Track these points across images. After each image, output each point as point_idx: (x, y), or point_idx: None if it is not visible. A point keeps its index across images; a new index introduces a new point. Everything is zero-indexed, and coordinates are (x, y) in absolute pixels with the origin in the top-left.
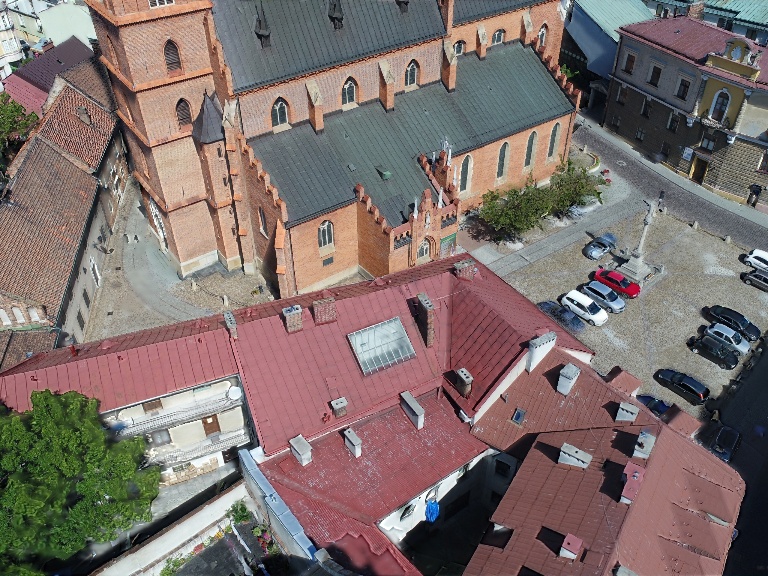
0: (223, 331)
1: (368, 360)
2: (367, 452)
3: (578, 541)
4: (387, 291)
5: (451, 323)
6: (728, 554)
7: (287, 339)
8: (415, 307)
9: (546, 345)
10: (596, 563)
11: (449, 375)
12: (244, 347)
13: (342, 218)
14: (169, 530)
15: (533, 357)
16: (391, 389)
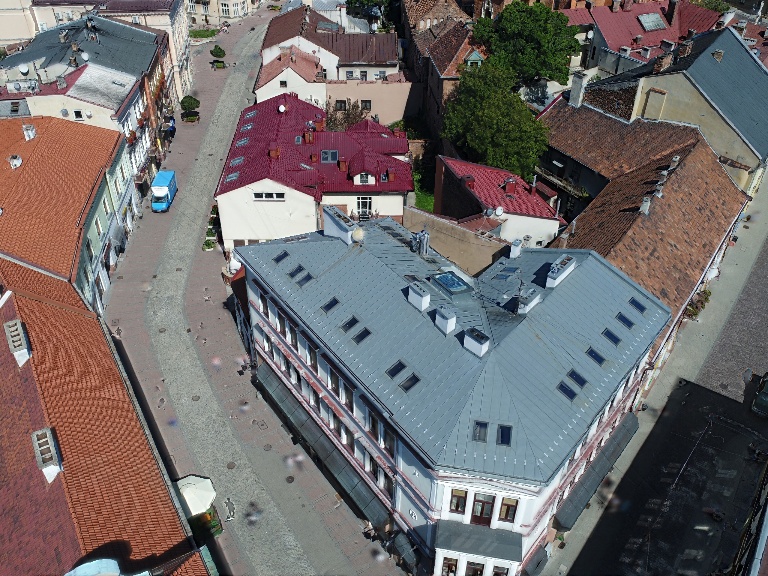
0: (585, 9)
1: (647, 26)
2: None
3: (759, 47)
4: (651, 3)
5: (680, 19)
6: None
7: (612, 15)
8: (664, 11)
9: (731, 14)
10: (766, 52)
11: (681, 38)
12: (595, 15)
13: (598, 4)
14: None
15: (725, 19)
16: (657, 39)
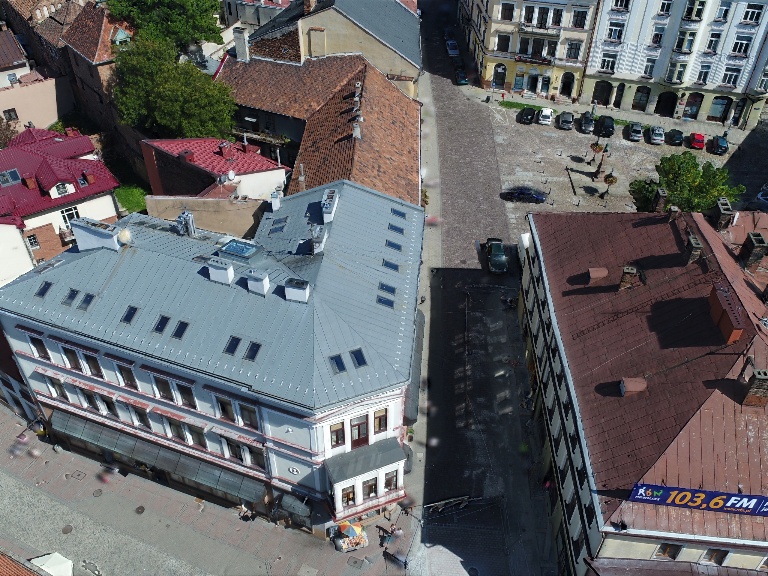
0: None
1: None
2: (283, 3)
3: None
4: None
5: None
6: (422, 34)
7: None
8: None
9: None
10: None
11: None
12: None
13: None
14: (223, 32)
15: None
16: None
